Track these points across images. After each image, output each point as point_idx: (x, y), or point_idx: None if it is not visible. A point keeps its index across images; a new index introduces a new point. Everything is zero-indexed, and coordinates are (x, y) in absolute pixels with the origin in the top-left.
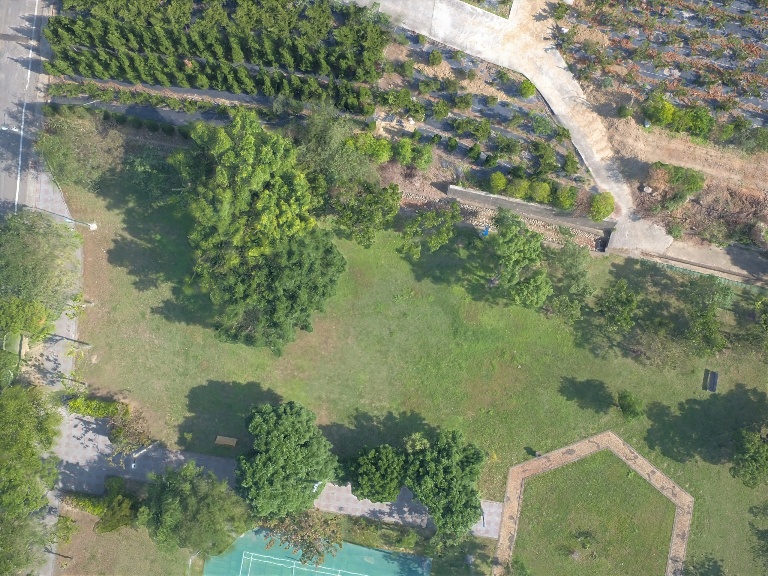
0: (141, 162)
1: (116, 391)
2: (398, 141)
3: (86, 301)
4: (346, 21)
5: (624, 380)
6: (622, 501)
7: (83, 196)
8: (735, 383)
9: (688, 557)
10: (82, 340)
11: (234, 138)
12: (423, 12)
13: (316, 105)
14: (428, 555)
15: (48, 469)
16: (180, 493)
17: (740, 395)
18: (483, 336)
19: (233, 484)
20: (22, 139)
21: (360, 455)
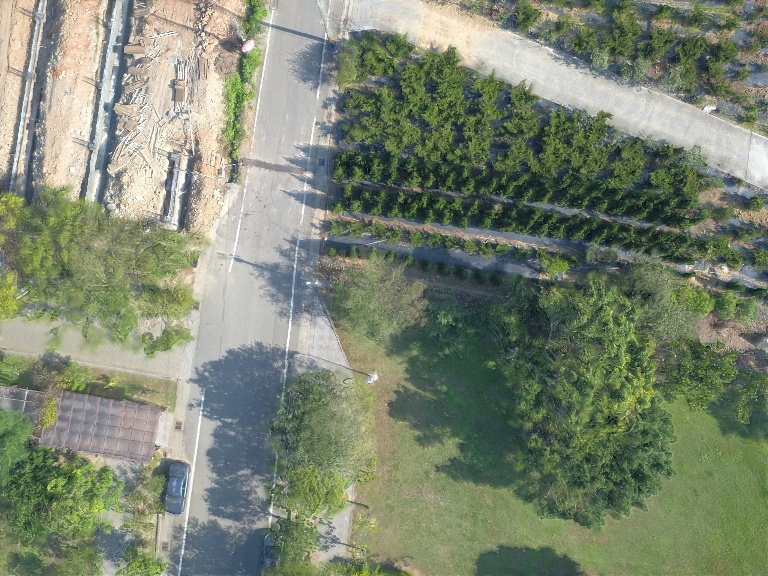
0: (445, 315)
1: (397, 558)
2: (711, 291)
3: None
4: (659, 162)
5: None
6: None
7: (363, 343)
8: None
9: None
10: (360, 501)
11: (591, 310)
12: (738, 153)
13: (623, 251)
14: None
15: None
16: None
17: None
18: None
19: None
20: (294, 279)
21: None
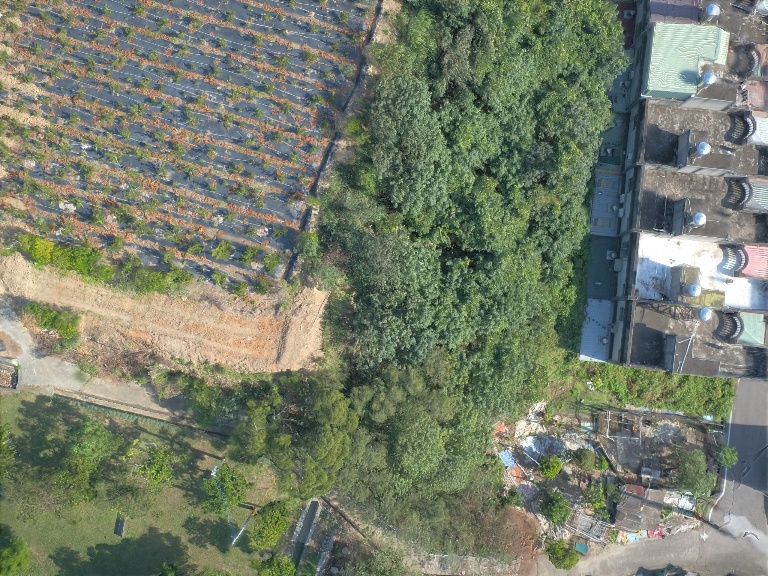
0: None
1: None
2: None
3: None
4: None
5: (31, 524)
6: None
7: None
8: (149, 527)
9: None
10: None
11: None
12: None
13: None
14: None
15: None
16: None
17: (154, 540)
18: None
19: None
20: None
21: None
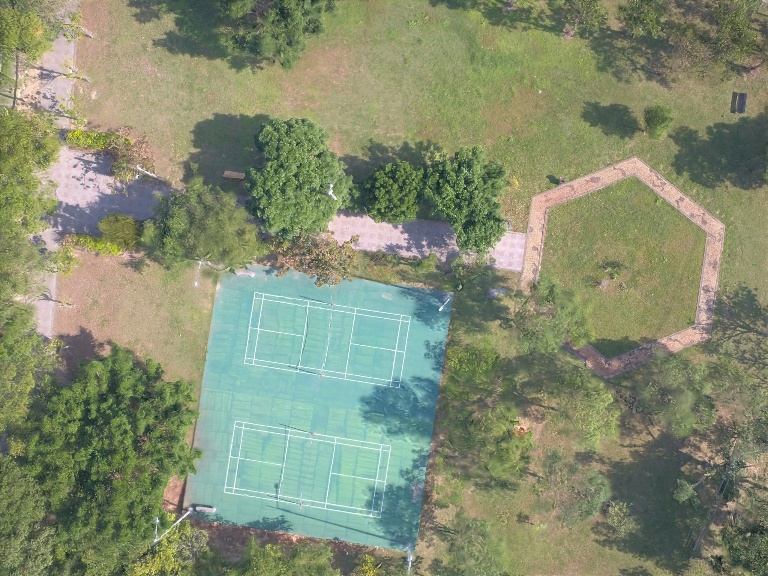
0: None
1: (117, 128)
2: None
3: (84, 35)
4: None
5: (649, 104)
6: (650, 229)
7: None
8: (764, 106)
9: (720, 286)
10: None
11: None
12: None
13: None
14: (449, 290)
15: (47, 193)
16: (187, 205)
17: None
18: (501, 61)
19: (243, 204)
20: None
21: (376, 171)
